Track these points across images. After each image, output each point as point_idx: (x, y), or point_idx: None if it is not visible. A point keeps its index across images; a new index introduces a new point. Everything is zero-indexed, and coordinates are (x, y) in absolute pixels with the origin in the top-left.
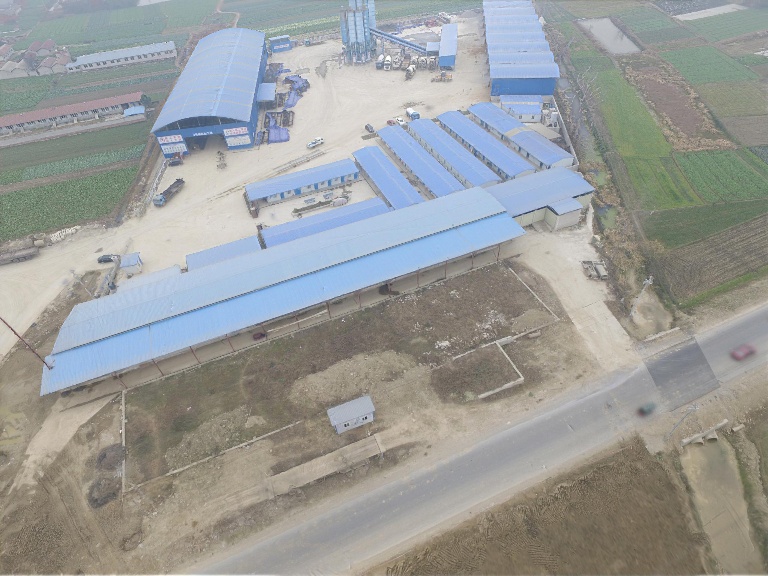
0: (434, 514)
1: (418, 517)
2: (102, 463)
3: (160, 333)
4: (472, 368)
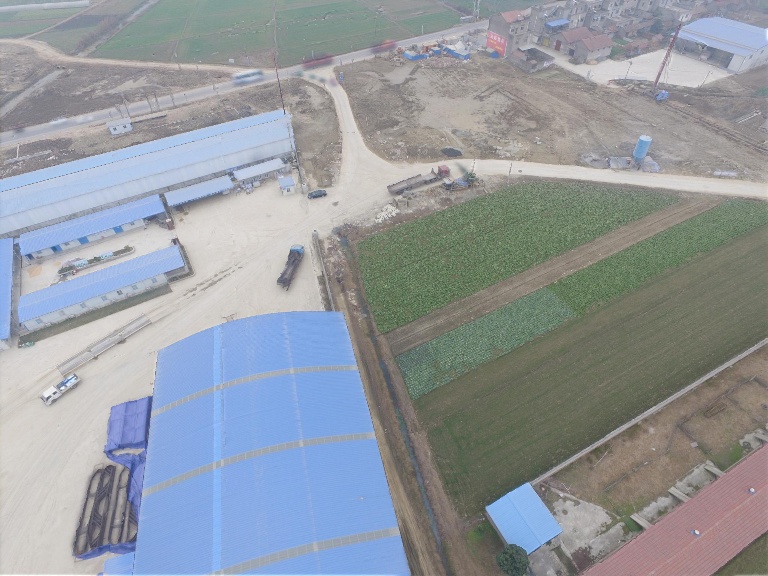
0: None
1: None
2: None
3: (226, 130)
4: (43, 145)
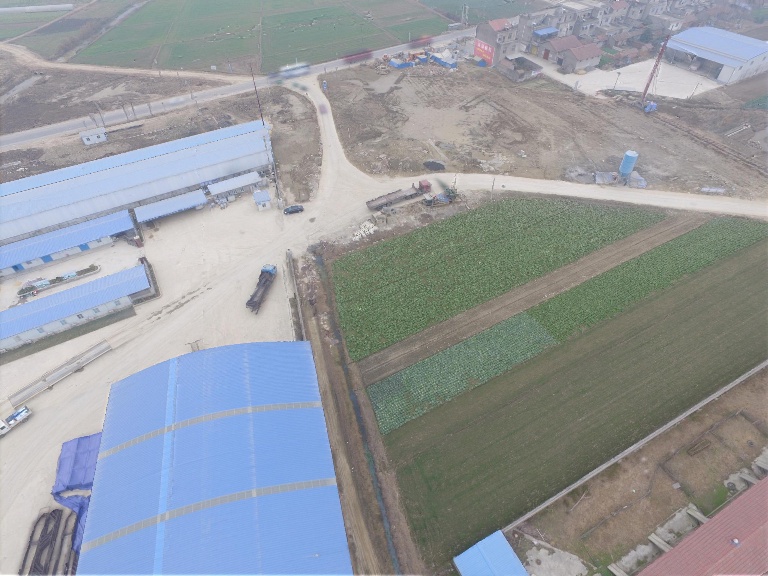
0: (73, 122)
1: (81, 121)
2: (227, 121)
3: (202, 141)
4: (12, 156)
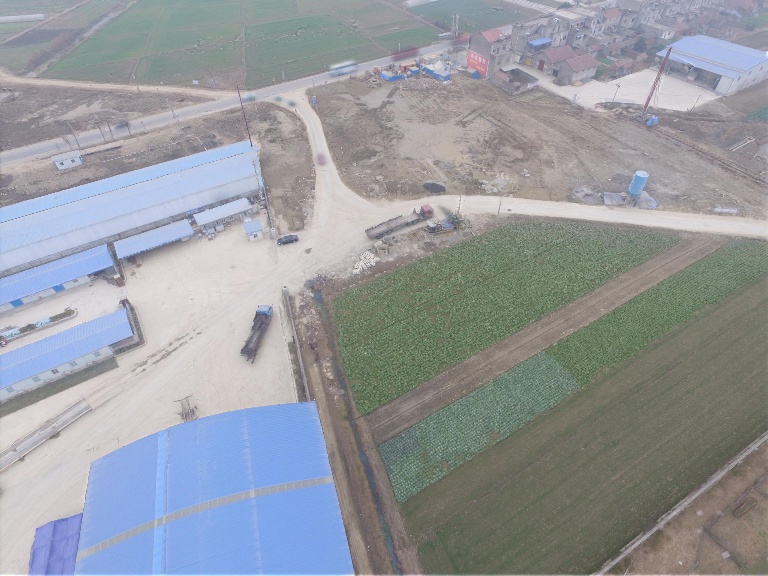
0: (45, 144)
1: (53, 143)
2: (212, 141)
3: (186, 165)
4: None
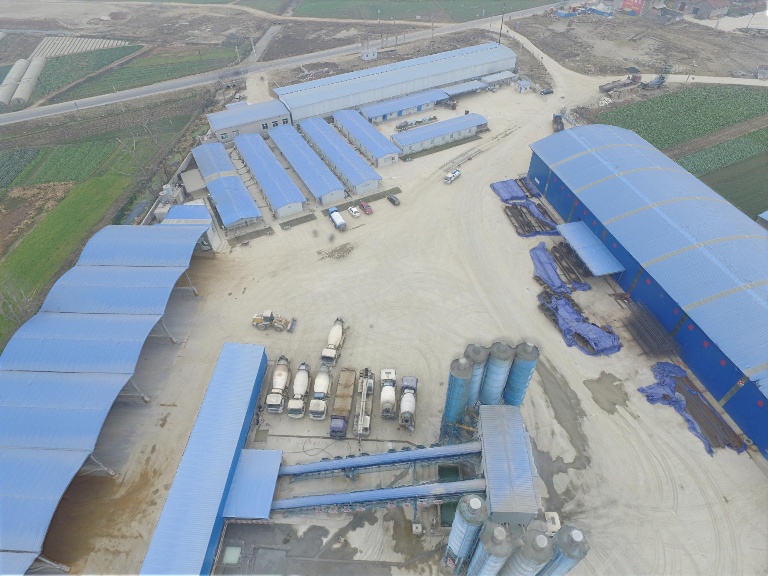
0: None
1: (346, 48)
2: None
3: (462, 53)
4: (321, 65)
